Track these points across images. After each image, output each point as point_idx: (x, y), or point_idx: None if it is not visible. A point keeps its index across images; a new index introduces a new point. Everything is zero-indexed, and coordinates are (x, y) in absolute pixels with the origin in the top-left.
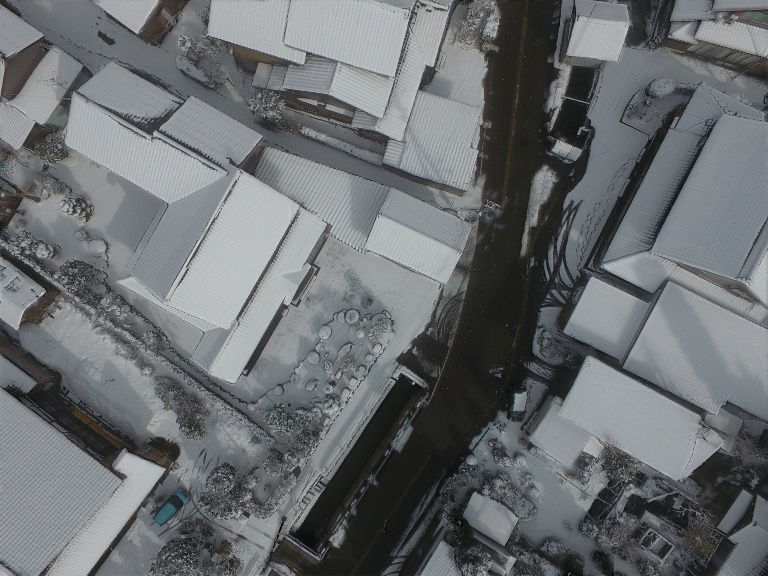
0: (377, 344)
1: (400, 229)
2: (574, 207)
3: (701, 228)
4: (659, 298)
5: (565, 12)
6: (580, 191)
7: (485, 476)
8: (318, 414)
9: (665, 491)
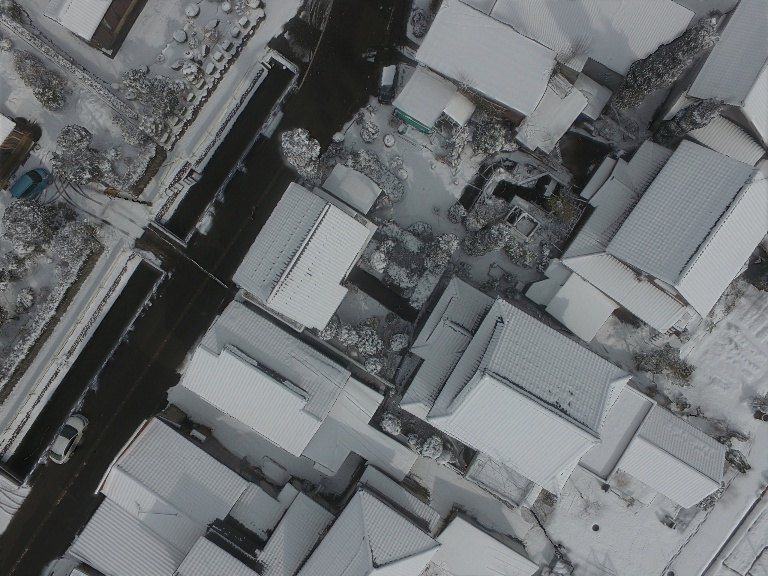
0: (243, 16)
1: None
2: None
3: None
4: None
5: None
6: None
7: (352, 153)
8: (180, 85)
9: (535, 174)
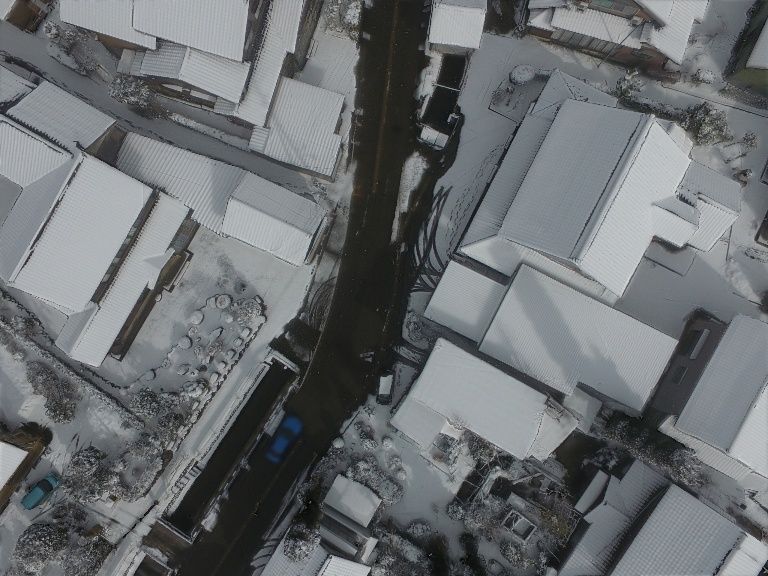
0: (245, 328)
1: (252, 212)
2: (444, 193)
3: (542, 210)
4: (513, 281)
5: None
6: (450, 177)
7: (351, 459)
8: (186, 398)
9: (530, 473)
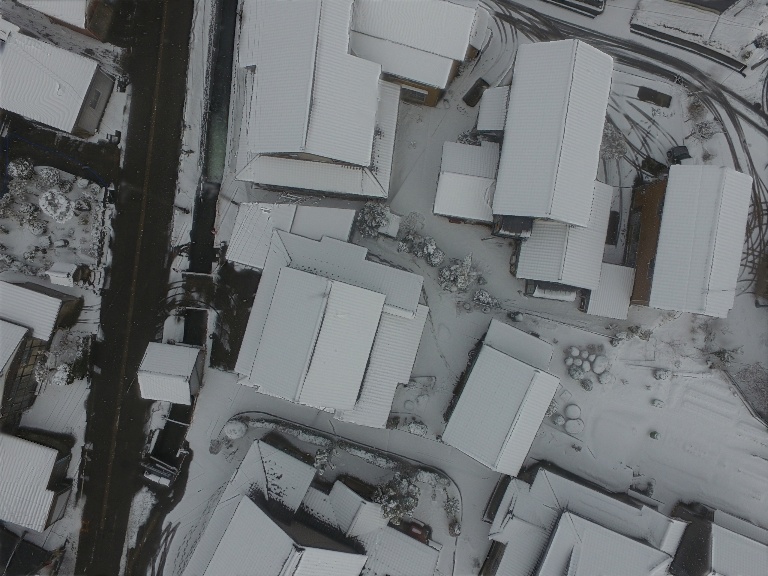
0: None
1: None
2: (172, 528)
3: None
4: None
5: (167, 334)
6: (178, 512)
7: None
8: None
9: None
